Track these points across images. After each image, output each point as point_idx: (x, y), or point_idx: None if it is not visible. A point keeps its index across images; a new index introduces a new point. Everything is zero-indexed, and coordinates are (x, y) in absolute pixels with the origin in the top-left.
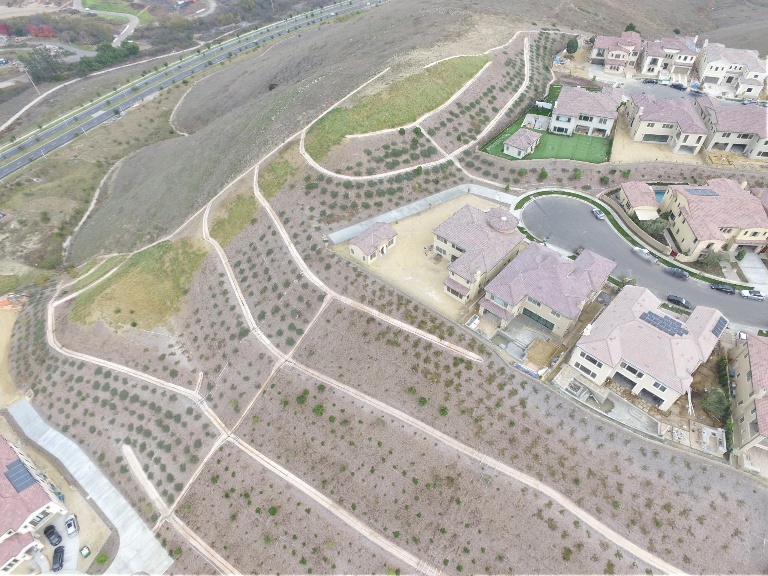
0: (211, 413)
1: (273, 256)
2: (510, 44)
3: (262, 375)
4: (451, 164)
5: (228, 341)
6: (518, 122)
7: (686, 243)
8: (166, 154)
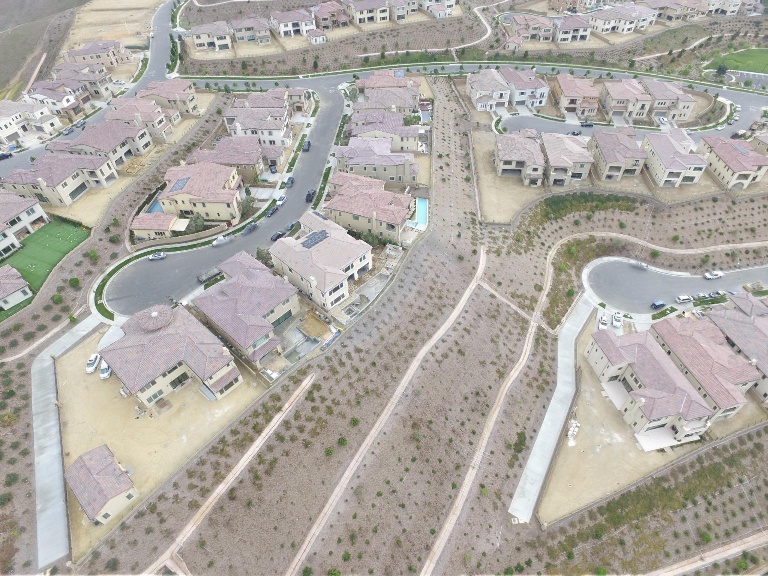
0: None
1: None
2: None
3: None
4: None
5: None
6: None
7: (223, 213)
8: None
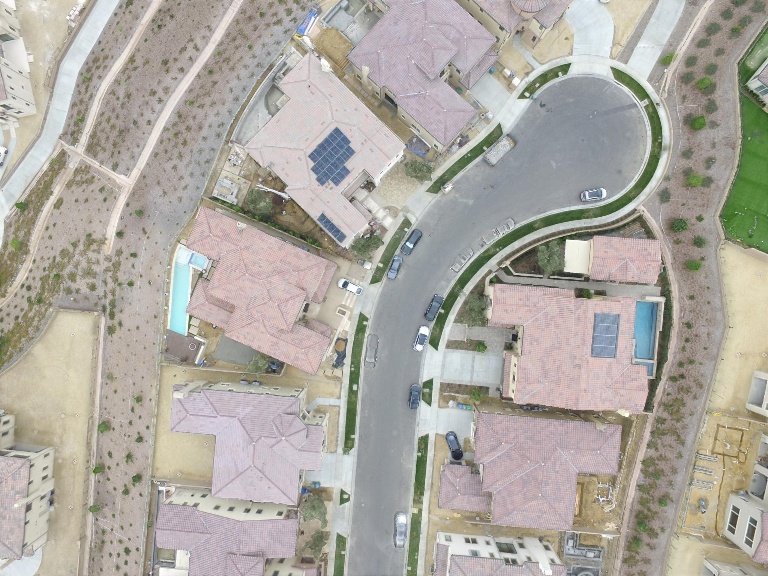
0: None
1: None
2: None
3: None
4: None
5: None
6: None
7: None
8: None
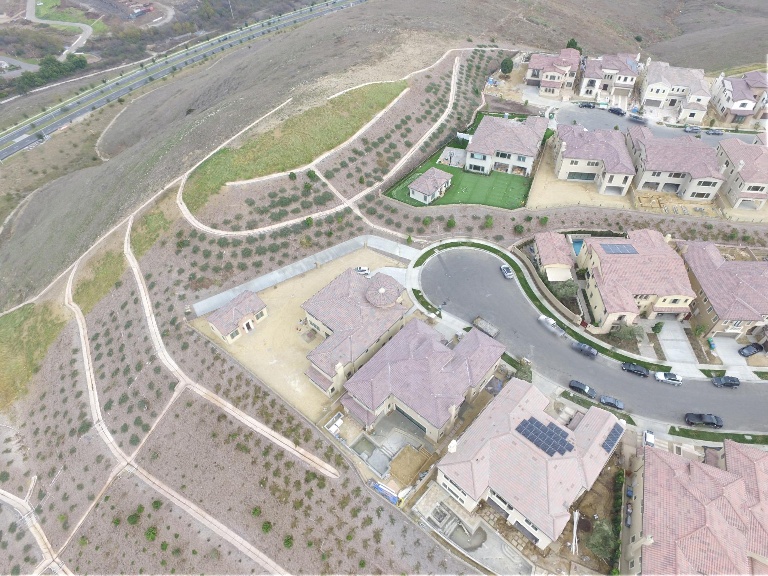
0: (38, 529)
1: (131, 330)
2: (436, 66)
3: (97, 483)
4: (348, 212)
5: (67, 437)
6: (434, 158)
7: (598, 311)
8: (69, 190)
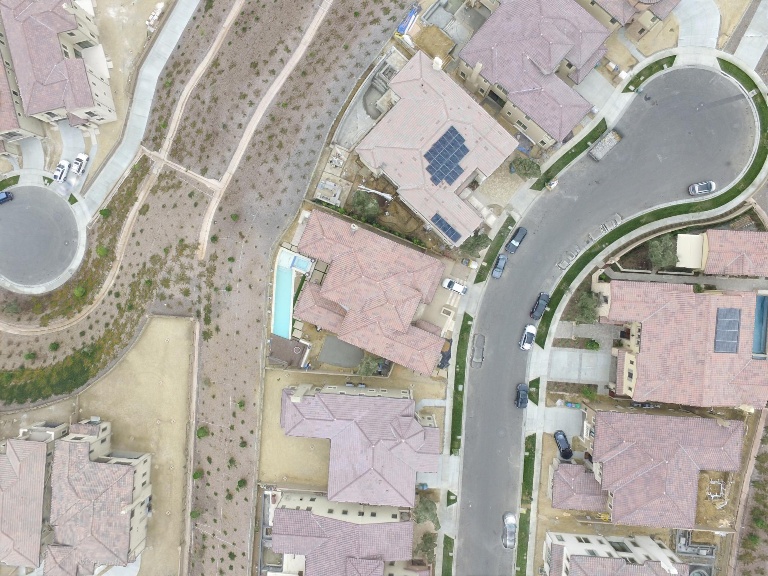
0: None
1: None
2: None
3: None
4: None
5: None
6: None
7: None
8: None
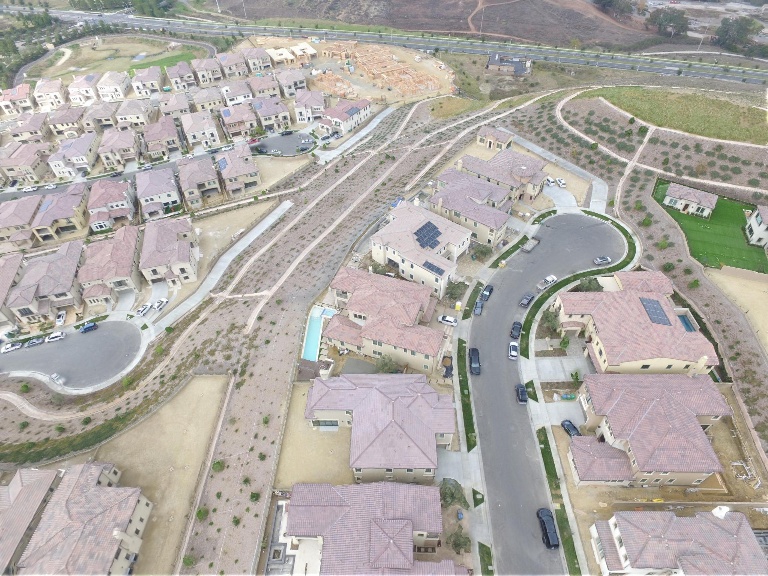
0: None
1: None
2: None
3: (403, 145)
4: (622, 165)
5: (423, 131)
6: (753, 207)
7: None
8: None
